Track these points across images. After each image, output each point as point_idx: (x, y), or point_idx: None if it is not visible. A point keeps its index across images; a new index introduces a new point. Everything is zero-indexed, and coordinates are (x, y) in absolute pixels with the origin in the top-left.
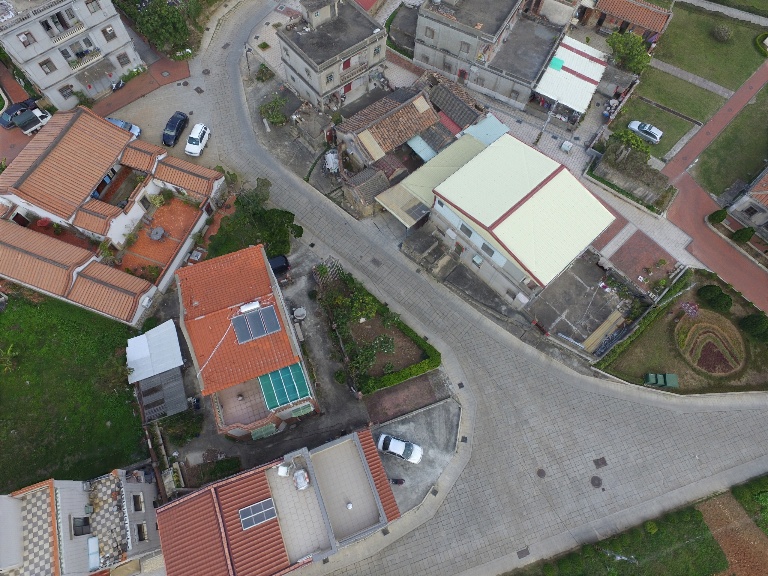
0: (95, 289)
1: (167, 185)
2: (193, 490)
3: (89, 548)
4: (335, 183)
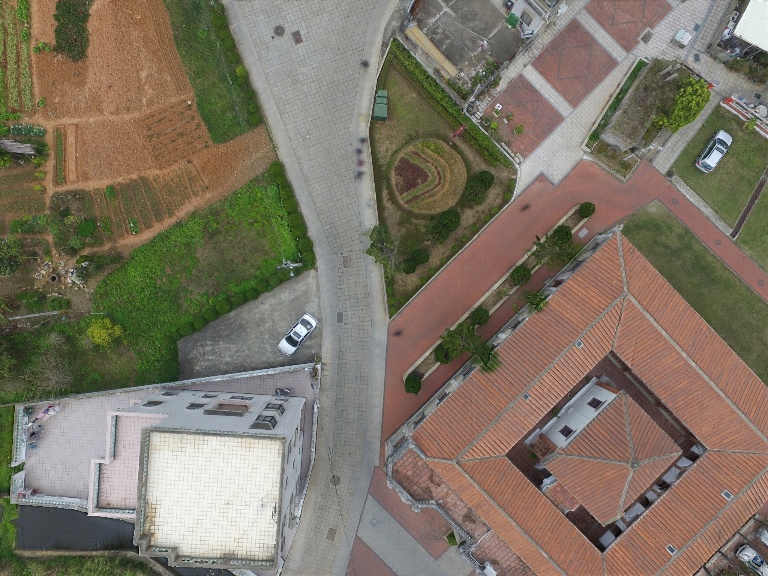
0: None
1: None
2: None
3: None
4: None
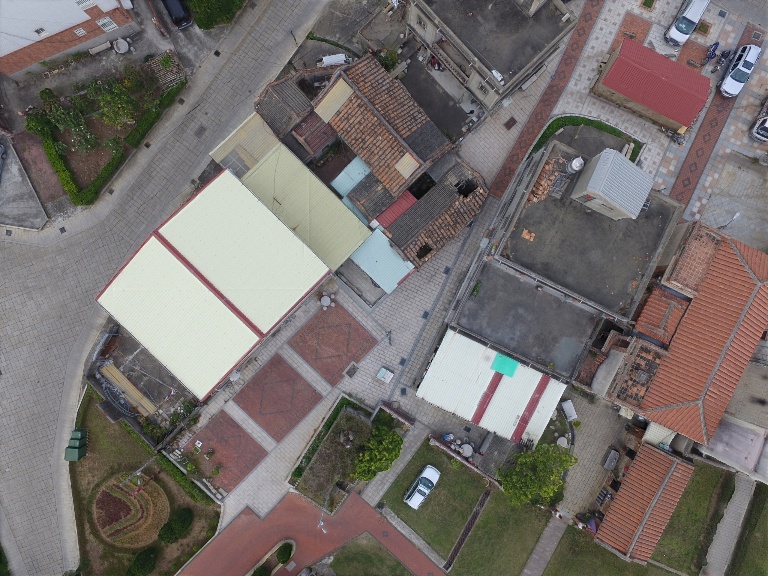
0: None
1: None
2: None
3: None
4: None
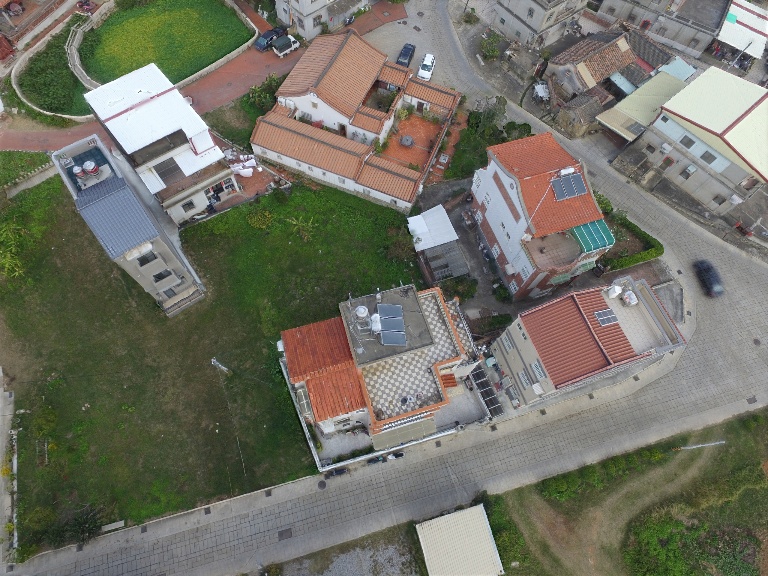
0: (379, 175)
1: (412, 101)
2: (479, 336)
3: None
4: (544, 110)
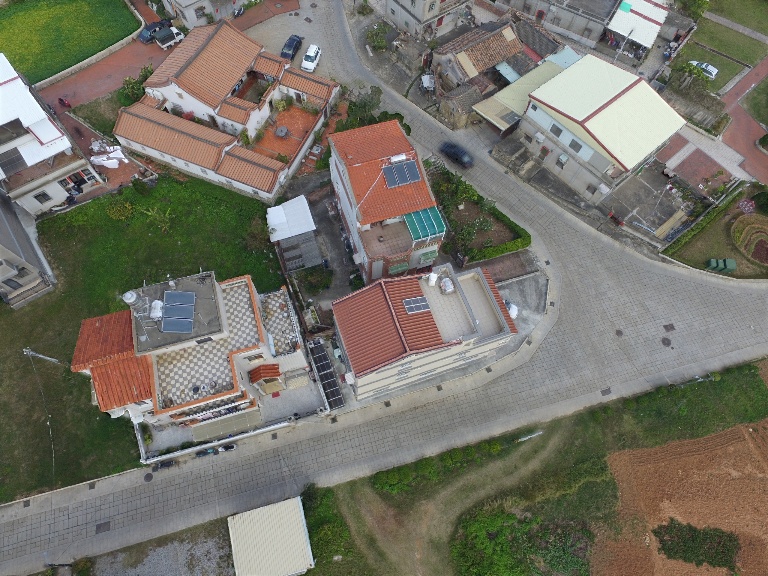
0: (240, 166)
1: (290, 92)
2: (328, 327)
3: (269, 339)
4: (430, 100)
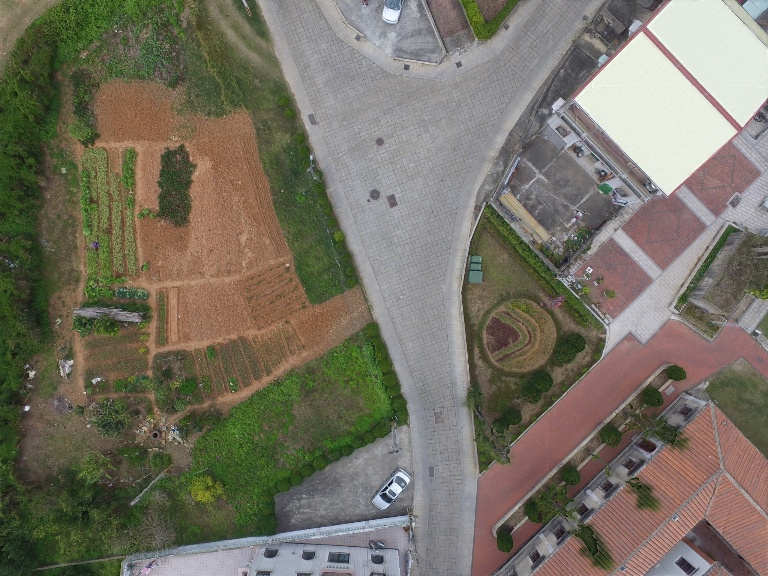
0: None
1: None
2: None
3: None
4: None
